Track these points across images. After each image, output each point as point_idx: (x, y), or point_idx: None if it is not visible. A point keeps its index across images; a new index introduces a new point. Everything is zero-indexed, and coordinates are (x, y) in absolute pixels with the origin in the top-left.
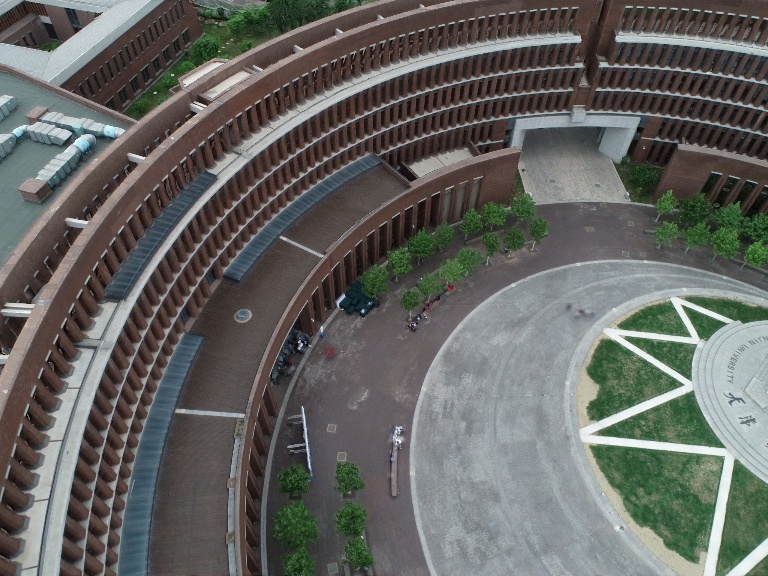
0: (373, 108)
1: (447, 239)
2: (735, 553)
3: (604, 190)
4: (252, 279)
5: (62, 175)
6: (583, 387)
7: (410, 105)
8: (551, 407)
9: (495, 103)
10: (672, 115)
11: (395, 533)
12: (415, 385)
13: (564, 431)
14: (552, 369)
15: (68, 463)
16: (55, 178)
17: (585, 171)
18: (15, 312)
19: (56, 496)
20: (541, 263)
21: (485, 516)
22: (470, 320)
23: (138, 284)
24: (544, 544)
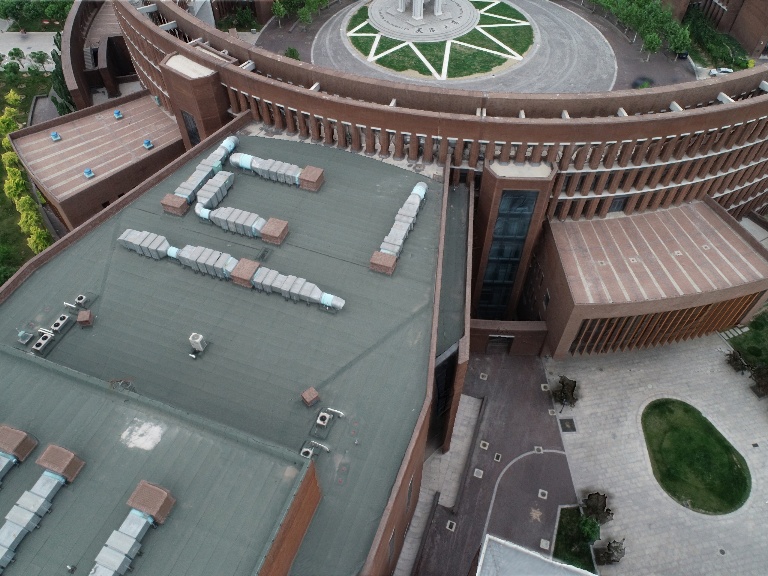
0: None
1: None
2: (501, 49)
3: None
4: None
5: None
6: (410, 74)
7: None
8: None
9: None
10: None
11: None
12: None
13: (439, 84)
14: None
15: None
16: None
17: None
18: None
19: None
20: None
21: None
22: None
23: None
24: None
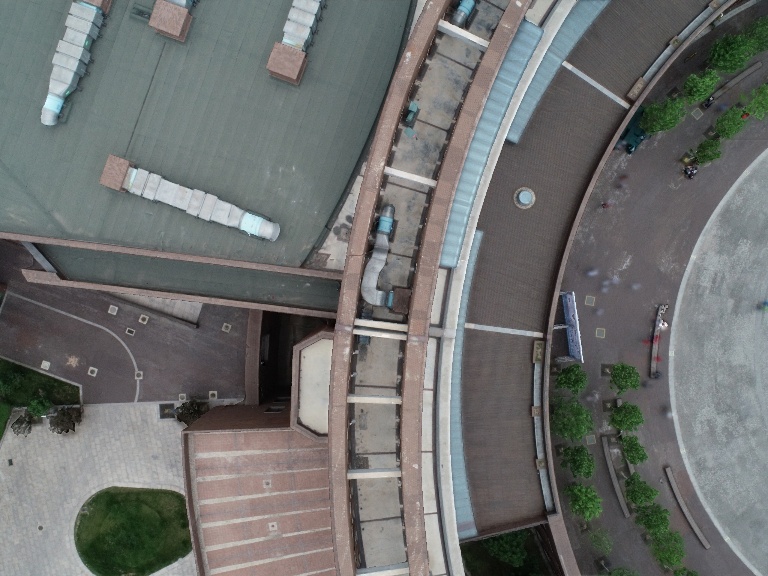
0: None
1: (767, 44)
2: None
3: None
4: (530, 138)
5: (314, 27)
6: None
7: None
8: None
9: None
10: None
11: (650, 411)
12: (684, 252)
13: None
14: None
15: (446, 477)
16: (309, 38)
17: None
18: (371, 335)
19: (445, 512)
20: None
21: (738, 399)
22: (760, 164)
23: (466, 240)
24: None
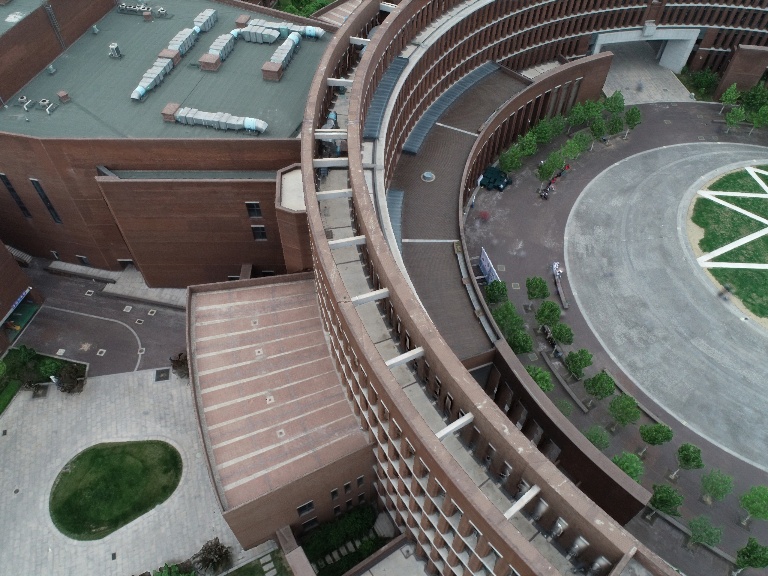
0: (498, 18)
1: (560, 128)
2: None
3: (672, 93)
4: (425, 153)
5: (287, 61)
6: (692, 231)
7: (522, 18)
8: (670, 245)
9: (584, 19)
10: (727, 26)
11: (574, 332)
12: (558, 236)
13: (685, 260)
14: (664, 220)
15: (390, 235)
16: (284, 63)
17: (652, 80)
18: (326, 134)
19: (392, 252)
20: (635, 148)
21: (640, 318)
22: (589, 190)
23: (382, 130)
24: (690, 332)
